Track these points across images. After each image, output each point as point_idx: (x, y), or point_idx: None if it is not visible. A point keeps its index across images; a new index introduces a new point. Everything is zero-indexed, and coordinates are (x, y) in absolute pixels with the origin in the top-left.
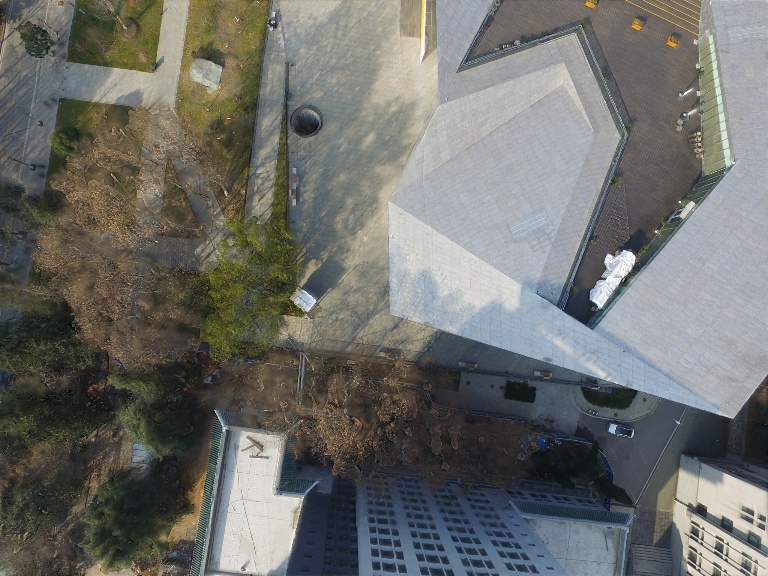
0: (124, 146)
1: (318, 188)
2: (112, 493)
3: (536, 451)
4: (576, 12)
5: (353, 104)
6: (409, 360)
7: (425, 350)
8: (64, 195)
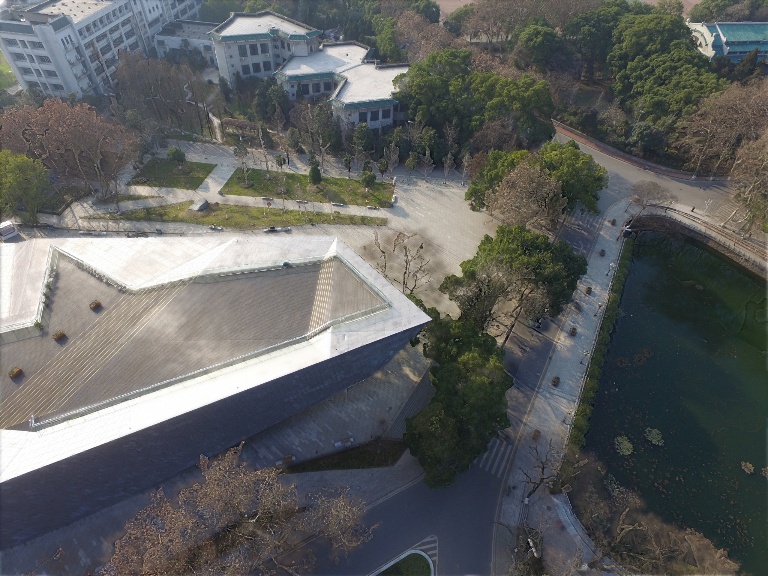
0: (177, 182)
1: None
2: None
3: None
4: (58, 325)
5: None
6: None
7: None
8: (161, 164)
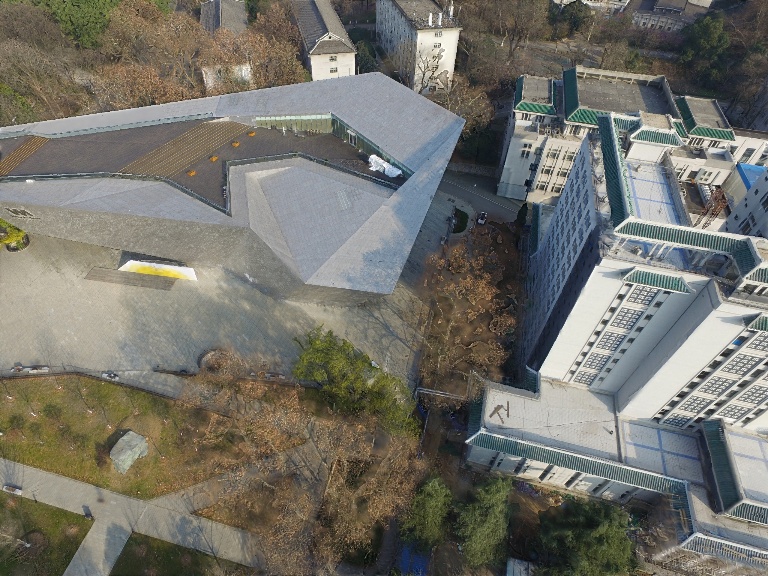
0: (163, 567)
1: (274, 359)
2: (552, 542)
3: (498, 260)
4: (216, 165)
5: (211, 327)
6: (428, 312)
7: (421, 302)
8: None
